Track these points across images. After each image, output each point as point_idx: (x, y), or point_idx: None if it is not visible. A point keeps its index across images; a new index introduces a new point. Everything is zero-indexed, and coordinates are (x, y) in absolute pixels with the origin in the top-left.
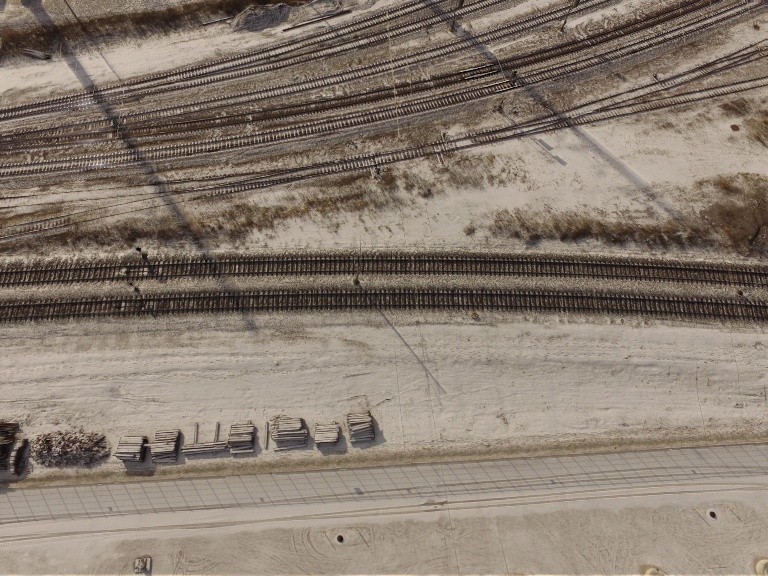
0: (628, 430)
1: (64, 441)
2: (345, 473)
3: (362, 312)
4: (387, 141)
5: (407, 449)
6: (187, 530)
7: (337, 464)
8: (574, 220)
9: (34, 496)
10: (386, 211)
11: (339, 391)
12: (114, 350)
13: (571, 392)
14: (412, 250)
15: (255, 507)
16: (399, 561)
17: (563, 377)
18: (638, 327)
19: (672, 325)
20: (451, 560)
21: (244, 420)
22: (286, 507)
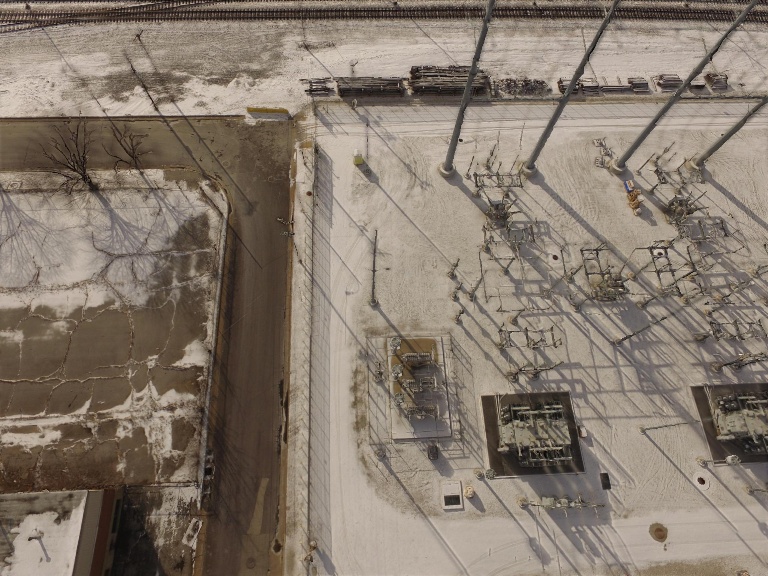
0: None
1: (520, 80)
2: (714, 104)
3: (695, 22)
4: None
5: (751, 94)
6: (621, 128)
7: (707, 100)
8: None
9: (511, 108)
10: None
11: (693, 65)
12: (531, 37)
13: None
14: None
15: (661, 118)
16: (766, 147)
17: None
18: None
19: None
20: None
21: (634, 77)
22: (681, 119)
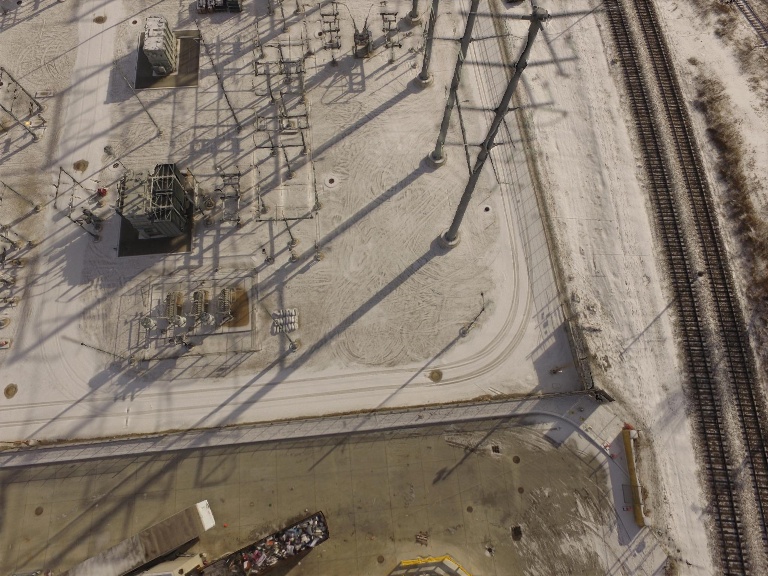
0: (543, 159)
1: None
2: None
3: None
4: (764, 8)
5: None
6: None
7: None
8: (734, 140)
9: None
10: (692, 7)
11: None
12: None
13: (566, 124)
14: (661, 23)
15: None
16: None
17: (578, 119)
18: (638, 178)
19: (647, 207)
20: (438, 42)
21: None
22: None
